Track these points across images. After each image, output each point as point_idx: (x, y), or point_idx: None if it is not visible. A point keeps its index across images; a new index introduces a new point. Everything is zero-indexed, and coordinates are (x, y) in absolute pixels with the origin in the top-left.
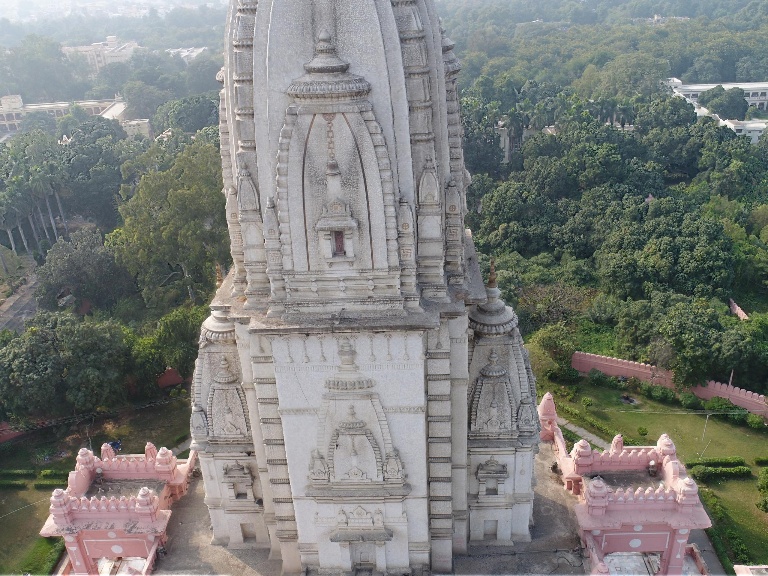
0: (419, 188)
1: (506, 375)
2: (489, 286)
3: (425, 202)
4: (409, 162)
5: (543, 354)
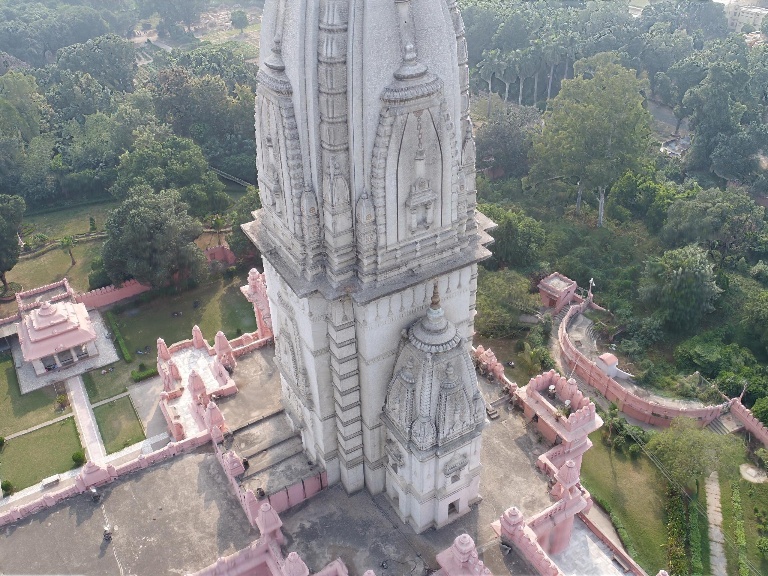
0: (323, 185)
1: (414, 385)
2: (430, 305)
3: (326, 199)
4: (315, 161)
5: (767, 463)
